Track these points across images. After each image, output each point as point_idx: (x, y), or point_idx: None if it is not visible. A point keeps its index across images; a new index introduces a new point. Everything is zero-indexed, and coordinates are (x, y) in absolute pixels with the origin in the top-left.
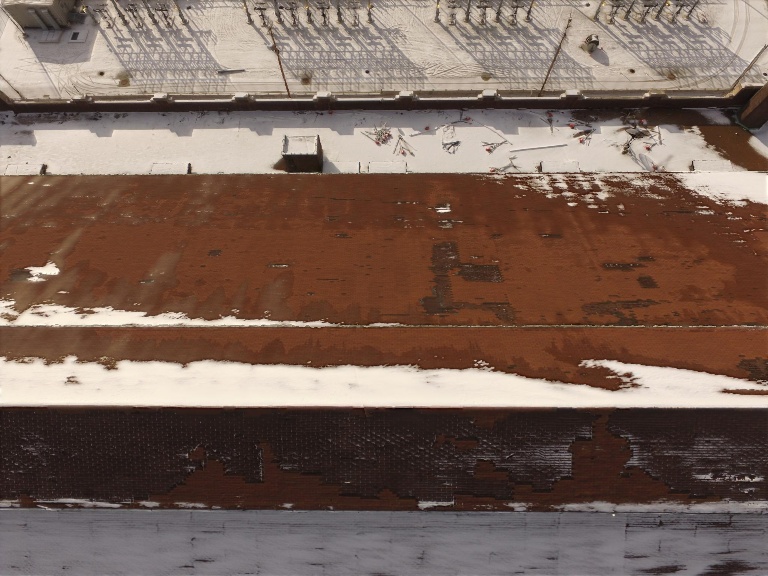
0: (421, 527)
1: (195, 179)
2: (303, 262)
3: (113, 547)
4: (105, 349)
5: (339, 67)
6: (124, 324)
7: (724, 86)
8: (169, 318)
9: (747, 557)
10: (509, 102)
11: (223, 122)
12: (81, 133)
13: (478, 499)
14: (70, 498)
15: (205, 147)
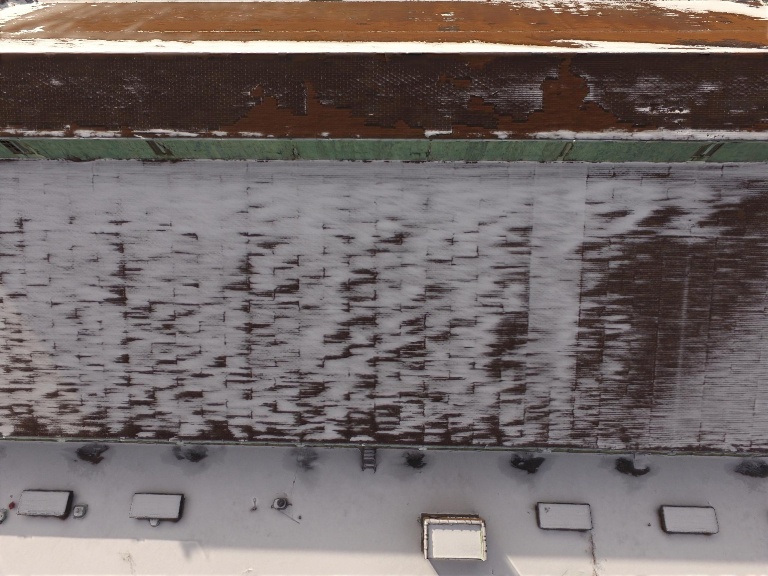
0: (426, 178)
1: (234, 3)
2: None
3: (186, 195)
4: (182, 37)
5: None
6: None
7: None
8: None
9: (682, 203)
10: None
11: None
12: None
13: (471, 128)
14: (159, 129)
15: None
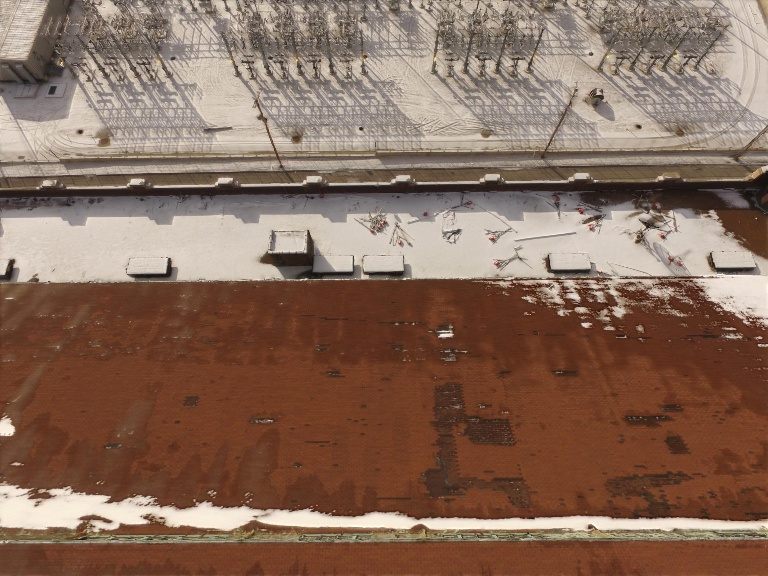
0: None
1: (173, 289)
2: (290, 415)
3: None
4: None
5: (331, 124)
6: (84, 515)
7: (735, 143)
8: (136, 505)
9: None
10: (513, 186)
11: (206, 208)
12: (52, 221)
13: None
14: None
15: (186, 237)
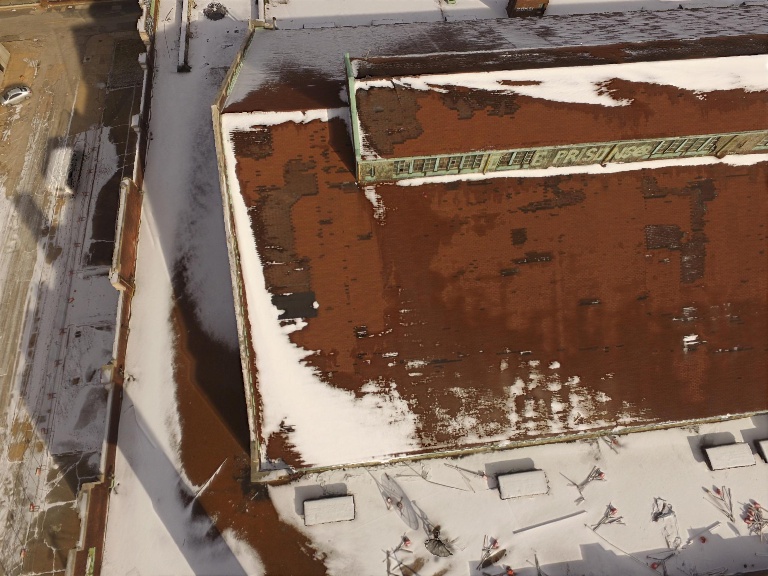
0: None
1: None
2: None
3: None
4: None
5: None
6: None
7: None
8: None
9: None
10: None
11: None
12: None
13: None
14: None
15: None
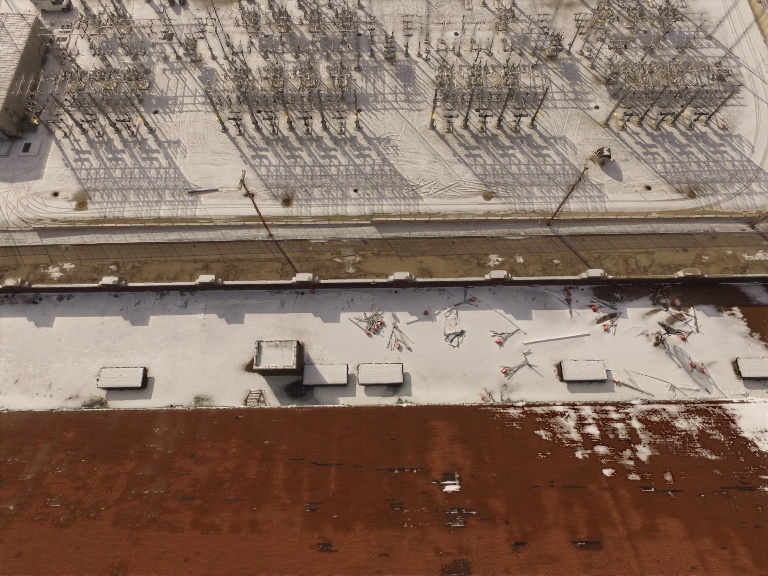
0: None
1: (146, 420)
2: None
3: None
4: None
5: (324, 185)
6: None
7: (749, 206)
8: None
9: None
10: (521, 281)
11: (186, 306)
12: (16, 322)
13: None
14: None
15: (164, 341)
